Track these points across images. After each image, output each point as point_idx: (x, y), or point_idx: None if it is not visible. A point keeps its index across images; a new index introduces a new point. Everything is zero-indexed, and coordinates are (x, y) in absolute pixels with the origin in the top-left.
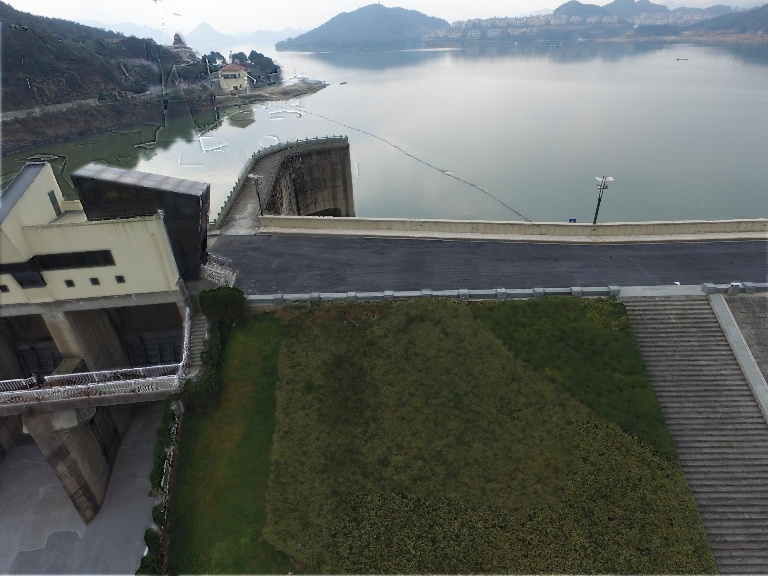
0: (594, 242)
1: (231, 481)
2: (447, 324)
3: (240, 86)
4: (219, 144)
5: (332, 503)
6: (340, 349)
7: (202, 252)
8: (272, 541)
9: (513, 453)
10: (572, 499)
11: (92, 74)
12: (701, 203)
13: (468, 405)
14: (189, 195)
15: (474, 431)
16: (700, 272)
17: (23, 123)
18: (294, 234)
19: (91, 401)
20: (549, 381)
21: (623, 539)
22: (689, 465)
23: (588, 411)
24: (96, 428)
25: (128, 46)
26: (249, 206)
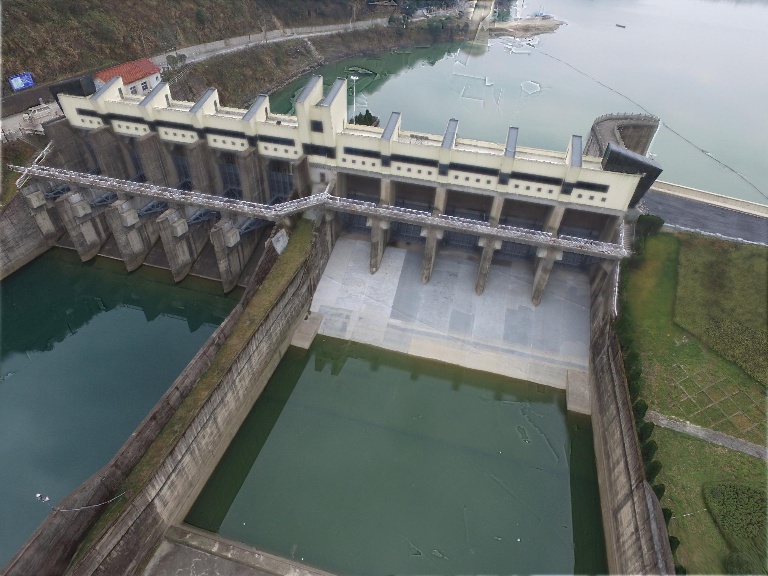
0: None
1: (651, 299)
2: None
3: None
4: (489, 82)
5: (706, 318)
6: (713, 259)
7: None
8: (679, 323)
9: None
10: None
11: None
12: None
13: None
14: (658, 168)
15: None
16: None
17: (343, 37)
18: (662, 192)
19: (581, 251)
20: None
21: None
22: None
23: None
24: None
25: None
26: None
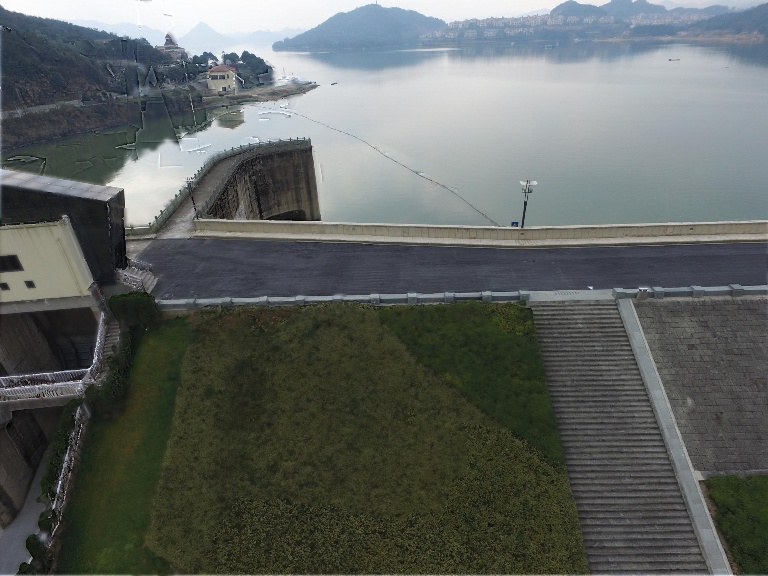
0: (521, 246)
1: (125, 487)
2: (353, 329)
3: (229, 87)
4: (200, 145)
5: (217, 509)
6: (244, 354)
7: (119, 257)
8: (153, 547)
9: (402, 459)
10: (455, 505)
11: (77, 75)
12: (665, 205)
13: (364, 410)
14: (95, 200)
15: (366, 436)
16: (616, 276)
17: (4, 124)
18: (228, 238)
19: None
20: (447, 386)
21: (500, 545)
22: (577, 470)
23: (482, 416)
24: (16, 432)
25: (118, 47)
26: (193, 209)
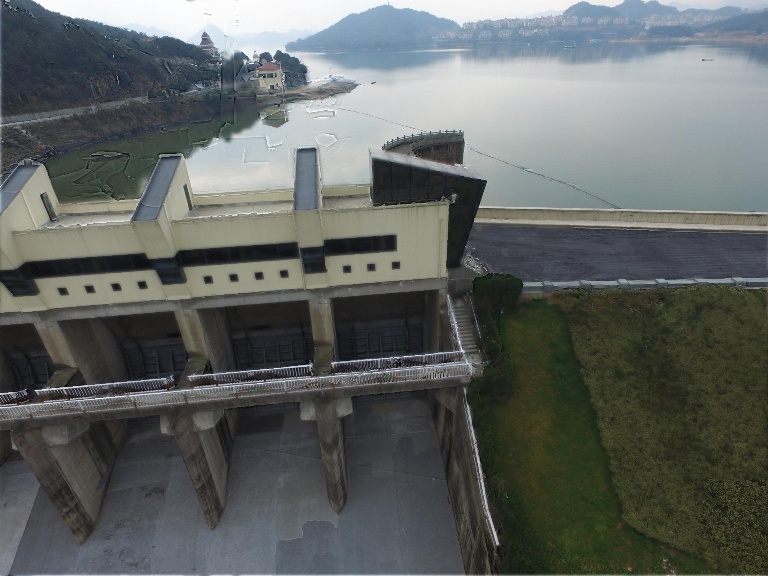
0: None
1: (557, 468)
2: (738, 312)
3: (277, 85)
4: (277, 142)
5: (689, 490)
6: (636, 336)
7: None
8: (640, 528)
9: None
10: None
11: (140, 72)
12: None
13: None
14: (476, 180)
15: None
16: None
17: (81, 120)
18: (497, 224)
19: (382, 387)
20: None
21: None
22: None
23: None
24: None
25: (162, 45)
26: None
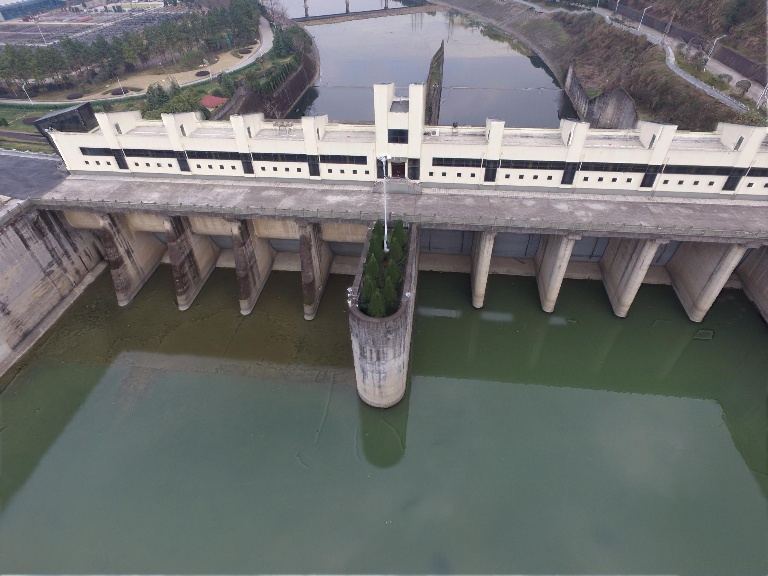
0: None
1: None
2: None
3: None
4: None
5: None
6: None
7: None
8: None
9: None
10: None
11: None
12: None
13: None
14: None
15: None
16: None
17: None
18: None
19: None
20: None
21: None
22: None
23: None
24: None
25: None
26: None
